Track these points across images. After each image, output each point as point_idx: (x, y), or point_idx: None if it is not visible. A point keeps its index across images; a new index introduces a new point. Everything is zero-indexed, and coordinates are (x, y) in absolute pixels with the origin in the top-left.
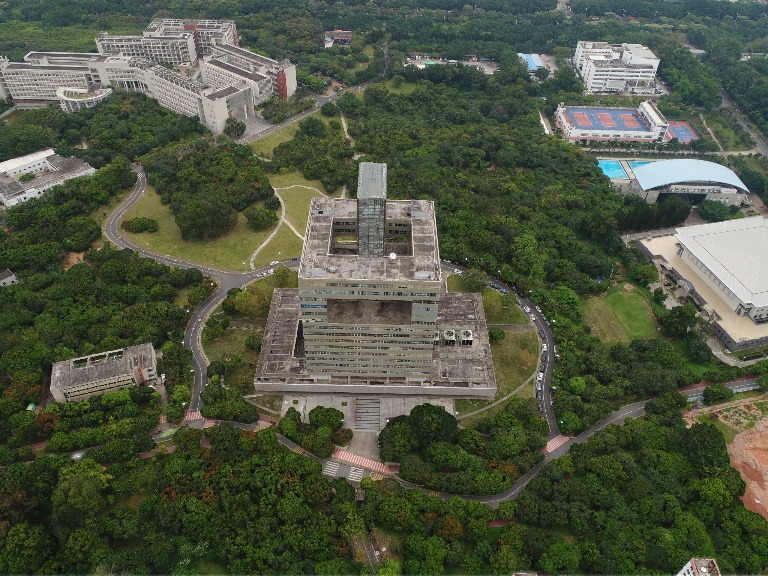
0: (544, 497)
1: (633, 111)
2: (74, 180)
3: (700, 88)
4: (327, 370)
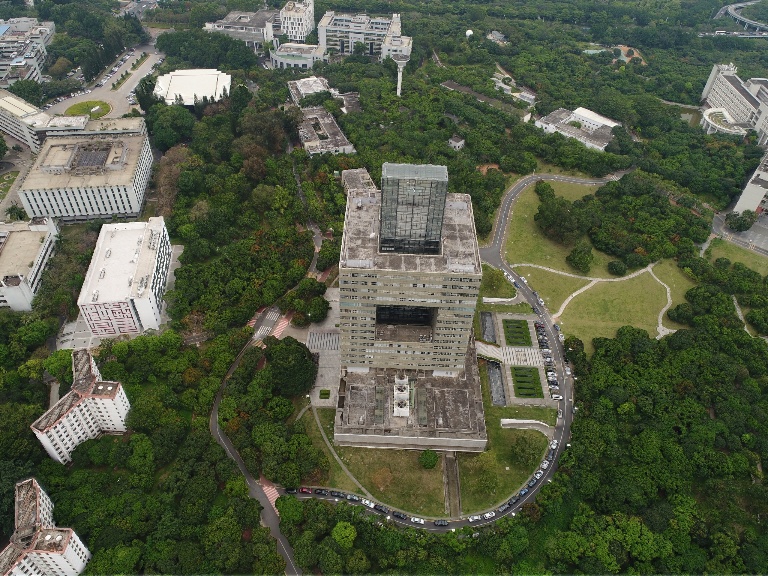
0: None
1: None
2: (573, 140)
3: None
4: None
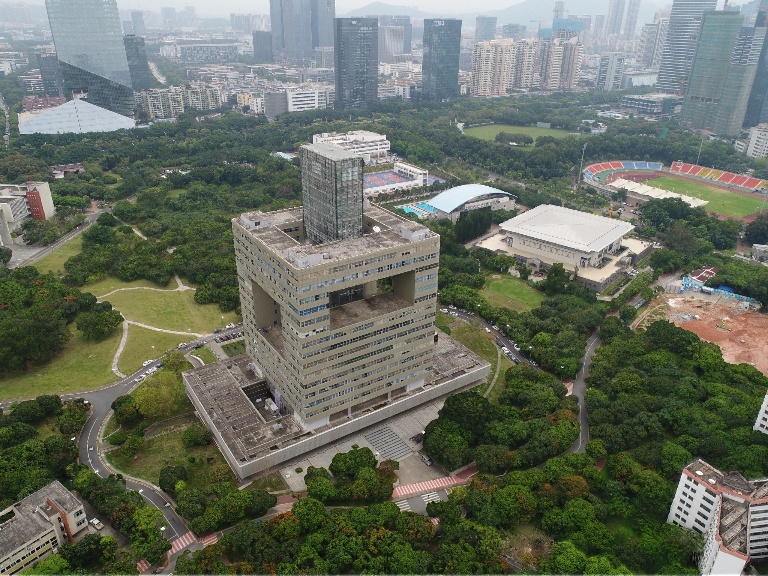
0: (612, 424)
1: (390, 172)
2: None
3: (427, 148)
4: (329, 407)
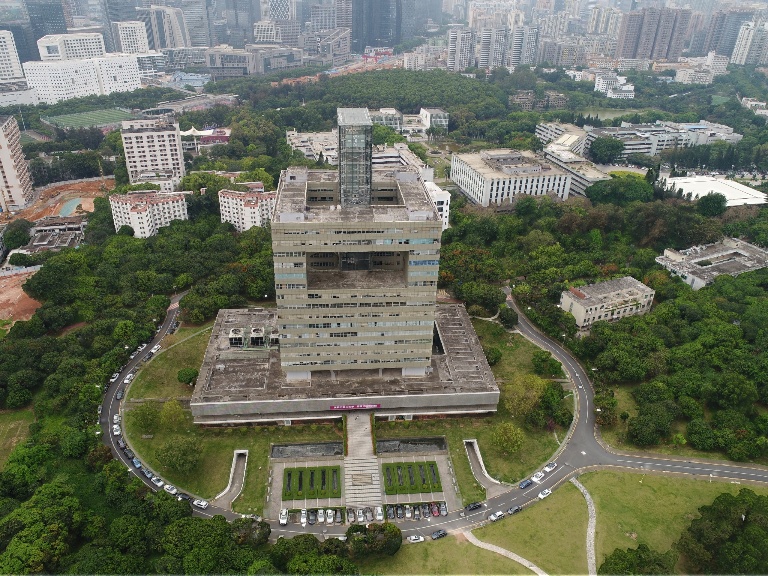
0: None
1: None
2: None
3: None
4: None
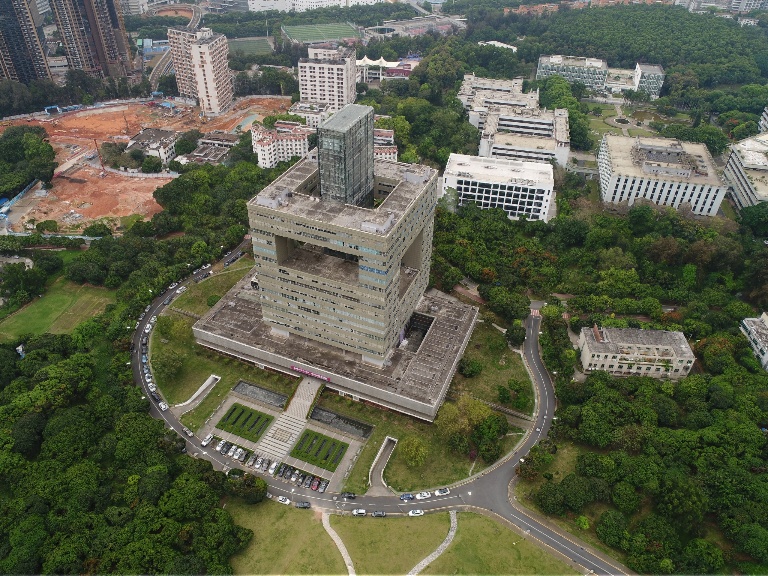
0: None
1: None
2: None
3: None
4: None
